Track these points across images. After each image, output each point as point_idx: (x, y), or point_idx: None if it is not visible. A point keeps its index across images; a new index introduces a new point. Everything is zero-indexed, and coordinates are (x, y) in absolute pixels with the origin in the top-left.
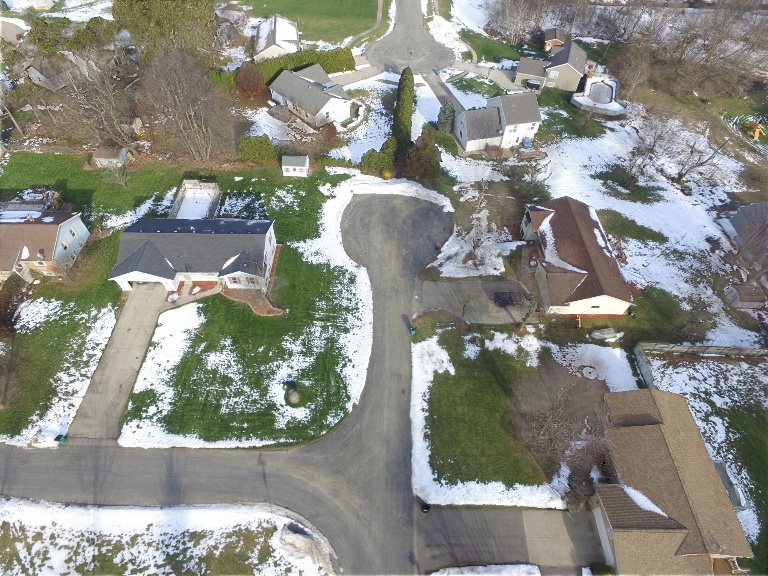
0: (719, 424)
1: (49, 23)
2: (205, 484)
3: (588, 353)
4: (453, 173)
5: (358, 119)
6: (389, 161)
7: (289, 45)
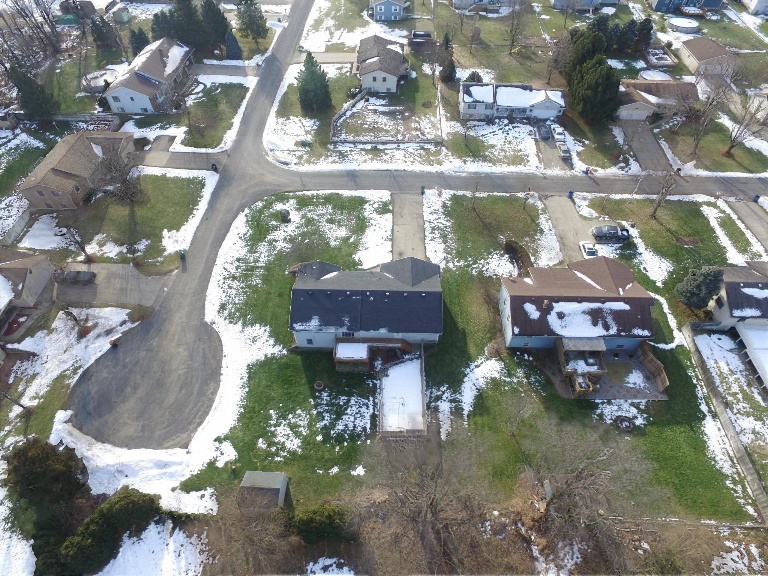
0: (4, 204)
1: None
2: (334, 177)
3: (49, 243)
4: (2, 512)
5: None
6: None
7: None
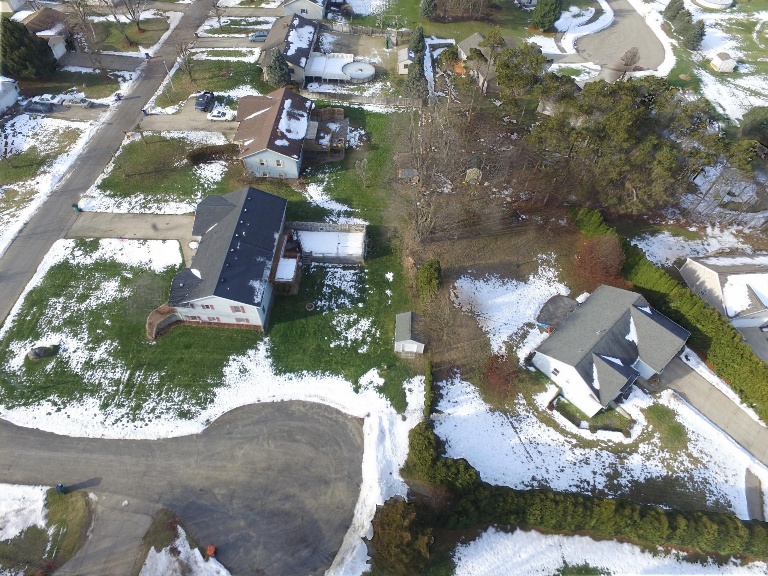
0: None
1: (681, 78)
2: None
3: None
4: None
5: (580, 429)
6: (427, 473)
7: (744, 297)
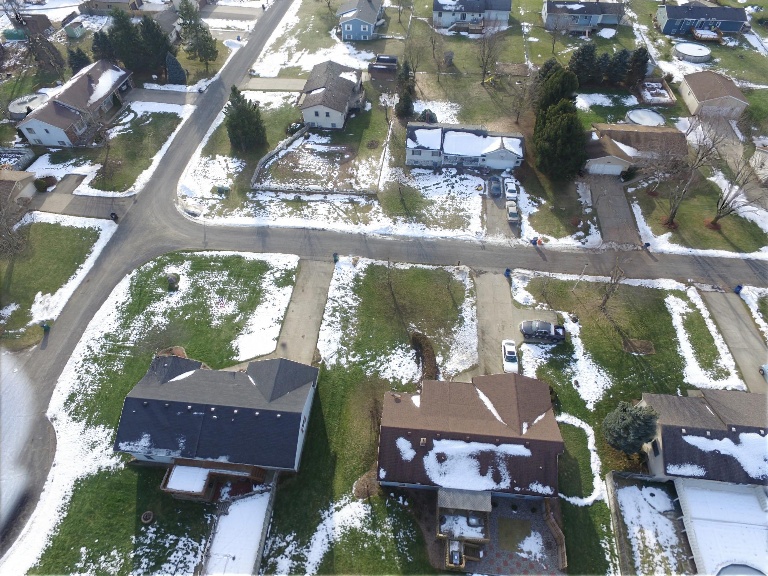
0: None
1: None
2: (242, 235)
3: None
4: None
5: None
6: None
7: None
